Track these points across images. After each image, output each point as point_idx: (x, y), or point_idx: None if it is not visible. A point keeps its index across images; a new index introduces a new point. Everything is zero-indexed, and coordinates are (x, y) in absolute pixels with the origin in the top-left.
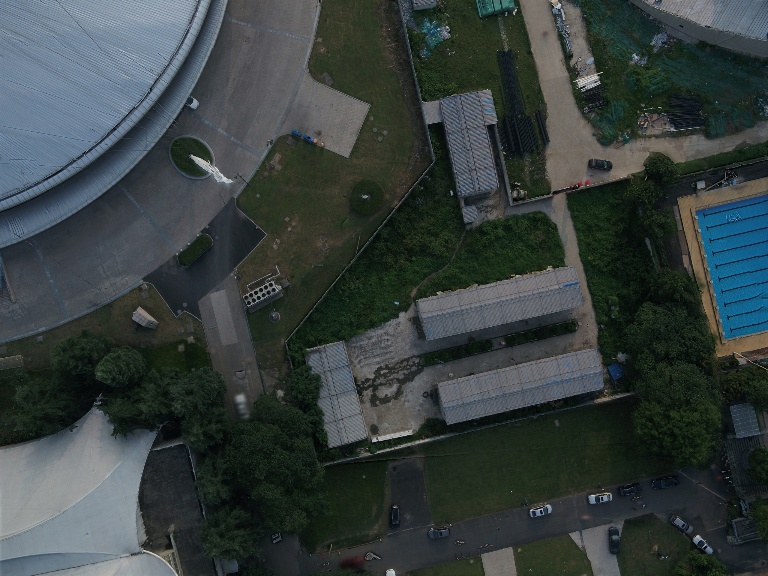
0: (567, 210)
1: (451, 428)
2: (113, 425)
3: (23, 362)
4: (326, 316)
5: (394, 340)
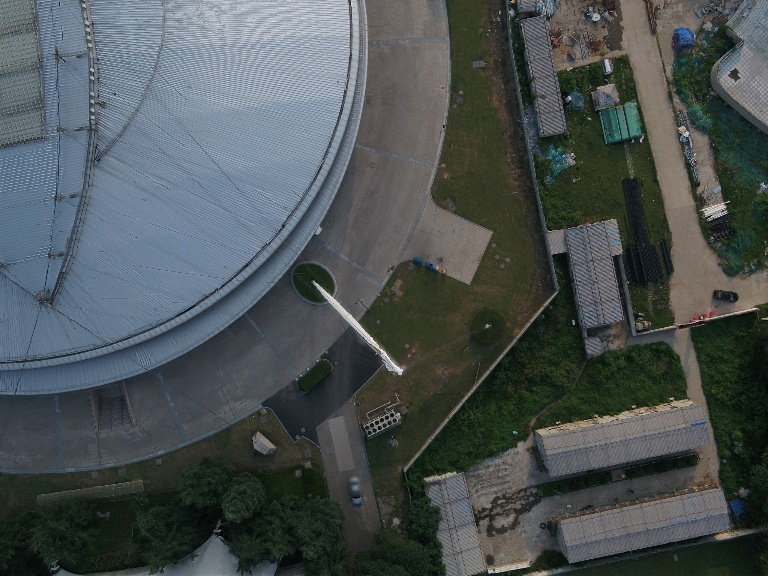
0: (690, 341)
1: None
2: (234, 556)
3: (143, 486)
4: (444, 445)
5: (512, 470)
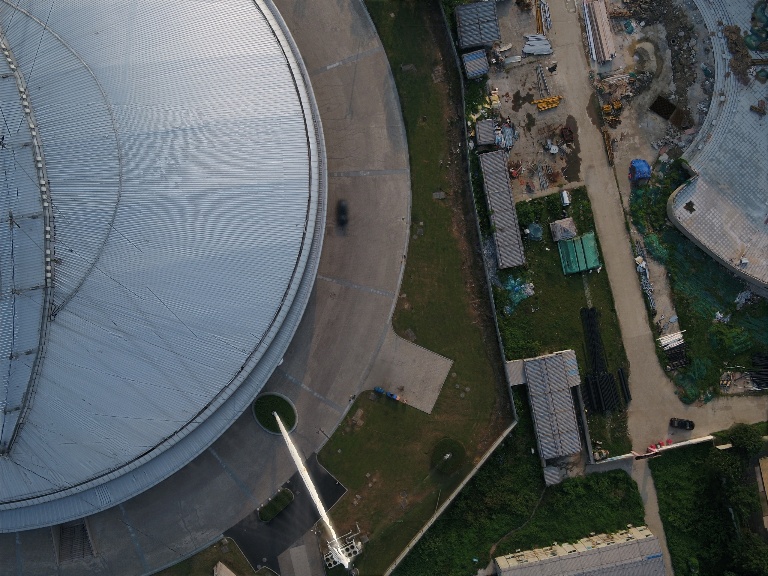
0: (648, 468)
1: None
2: None
3: None
4: (405, 573)
5: None
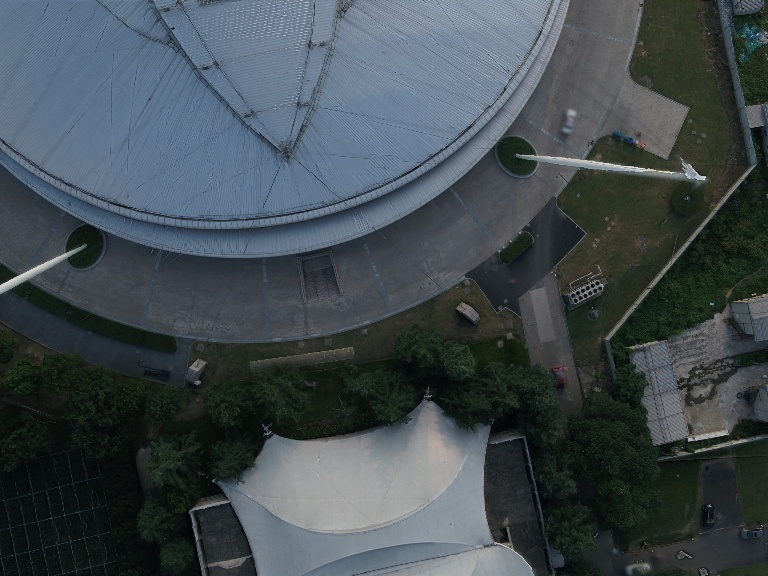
0: None
1: (765, 429)
2: (449, 418)
3: None
4: (644, 315)
5: (709, 341)
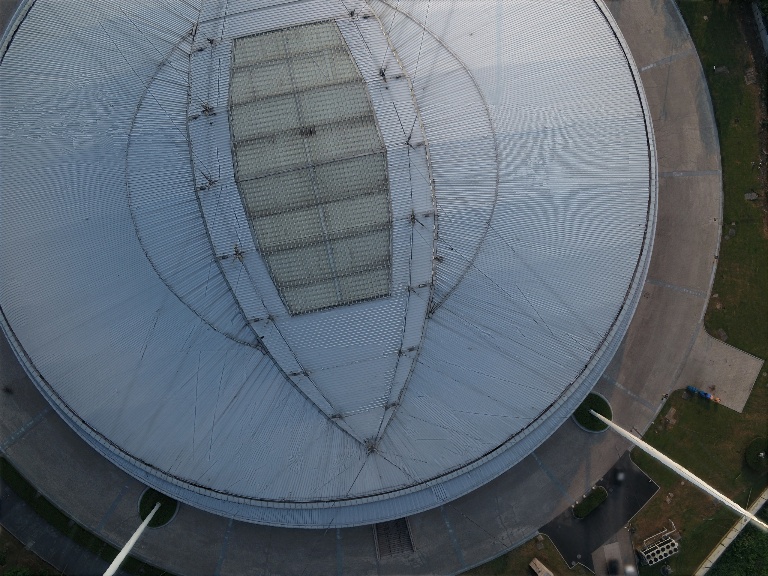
0: None
1: None
2: None
3: None
4: (717, 571)
5: None
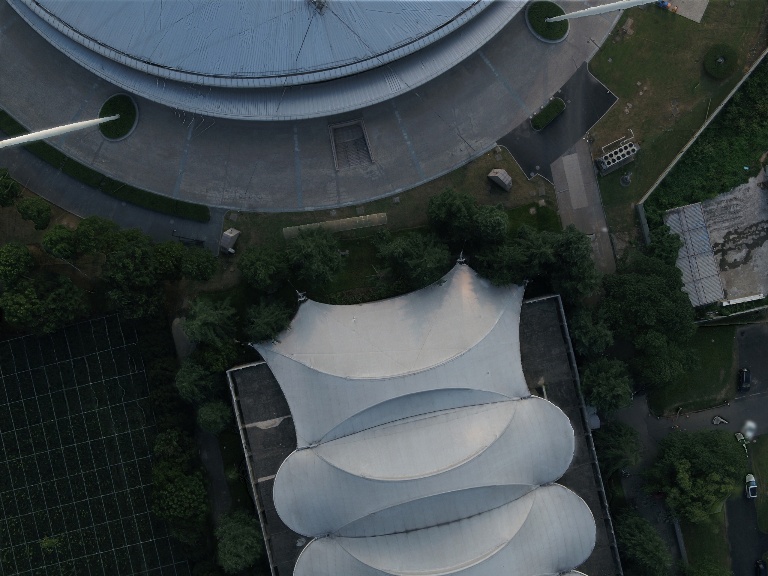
0: None
1: None
2: (483, 279)
3: None
4: (677, 180)
5: (743, 205)
